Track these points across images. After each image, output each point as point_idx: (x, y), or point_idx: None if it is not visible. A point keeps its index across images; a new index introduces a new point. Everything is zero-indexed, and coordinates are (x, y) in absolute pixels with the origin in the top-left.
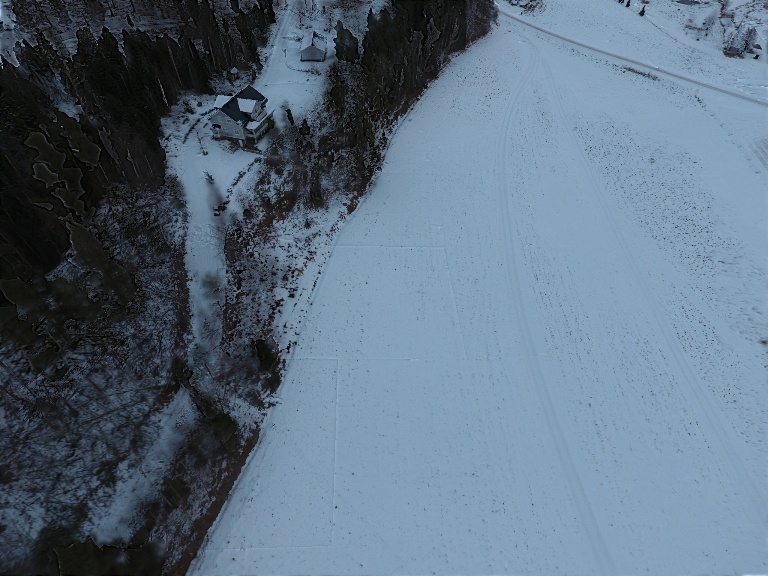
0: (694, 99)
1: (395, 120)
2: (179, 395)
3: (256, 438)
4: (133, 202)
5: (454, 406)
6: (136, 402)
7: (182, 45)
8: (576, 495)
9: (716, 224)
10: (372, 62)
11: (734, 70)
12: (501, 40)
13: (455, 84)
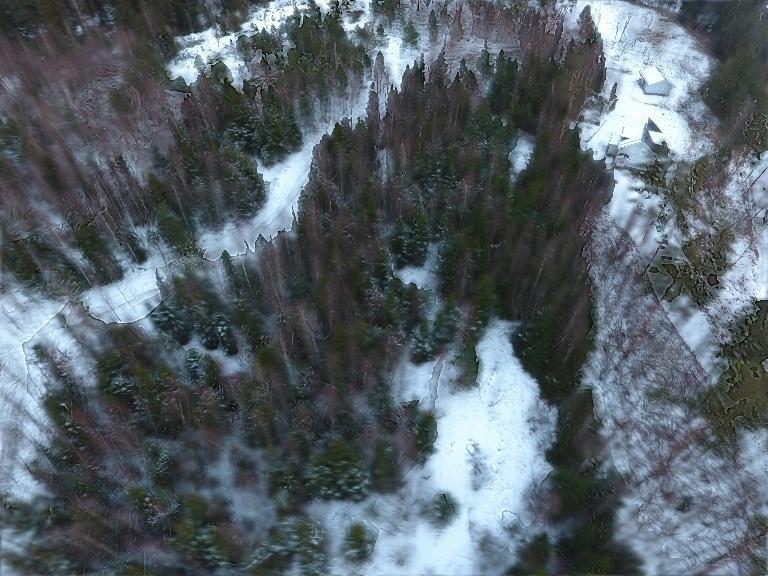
0: None
1: (744, 162)
2: (740, 439)
3: None
4: (595, 226)
5: None
6: (719, 442)
7: None
8: None
9: None
10: None
11: None
12: None
13: None
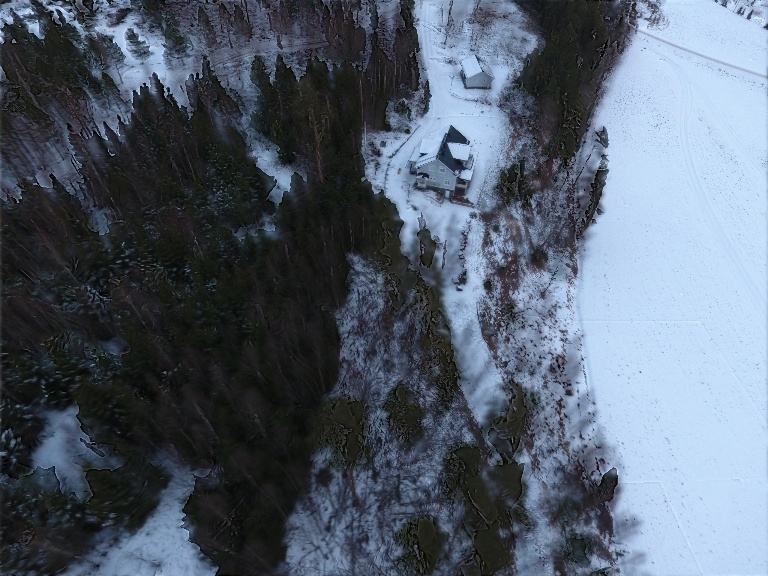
0: None
1: None
2: (519, 550)
3: None
4: (374, 279)
5: None
6: None
7: None
8: None
9: None
10: (579, 97)
11: None
12: (640, 58)
13: (618, 112)
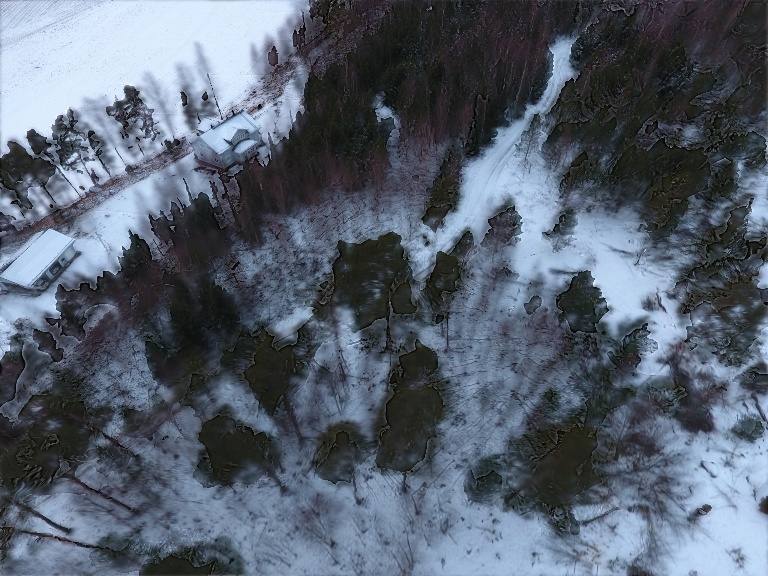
0: None
1: None
2: None
3: None
4: None
5: None
6: None
7: None
8: None
9: None
10: None
11: None
12: None
13: None
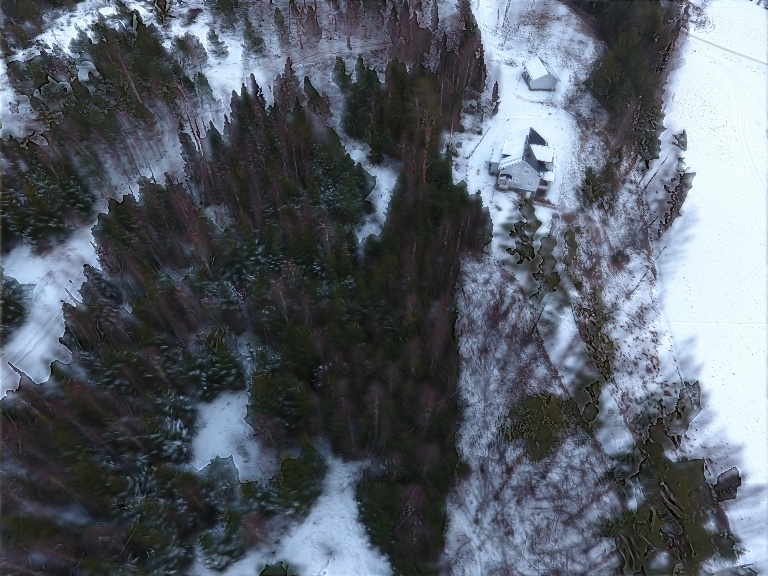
0: None
1: None
2: None
3: None
4: (475, 278)
5: None
6: None
7: None
8: None
9: None
10: (654, 100)
11: None
12: (691, 61)
13: (677, 115)
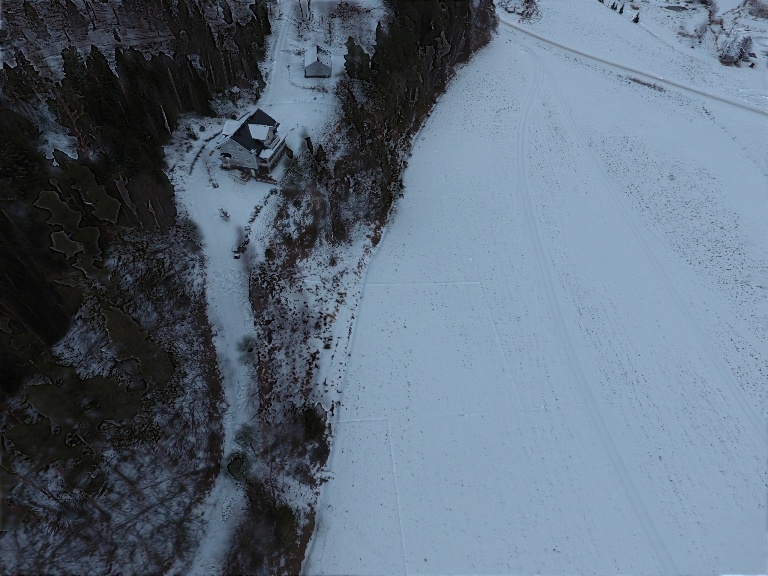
0: (702, 111)
1: None
2: (220, 479)
3: (312, 524)
4: (144, 248)
5: (520, 468)
6: (174, 494)
7: (177, 62)
8: (665, 566)
9: (746, 245)
10: (388, 81)
11: (734, 79)
12: (503, 50)
13: (464, 98)
